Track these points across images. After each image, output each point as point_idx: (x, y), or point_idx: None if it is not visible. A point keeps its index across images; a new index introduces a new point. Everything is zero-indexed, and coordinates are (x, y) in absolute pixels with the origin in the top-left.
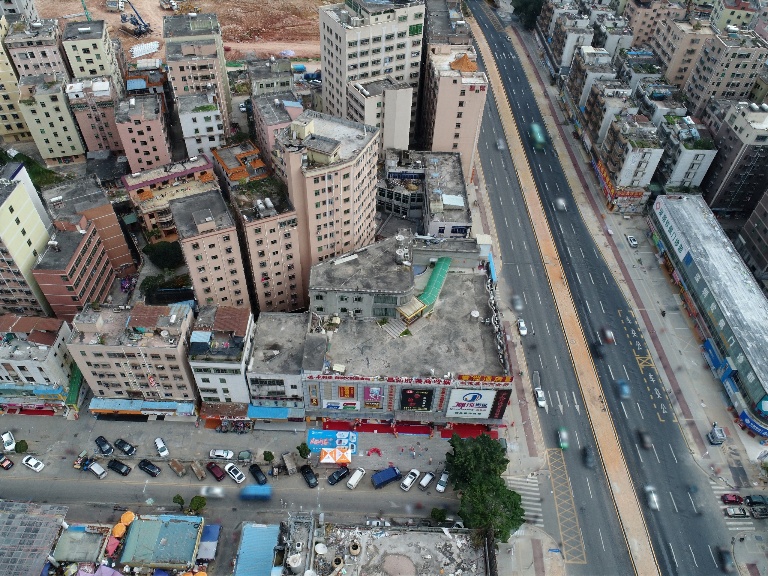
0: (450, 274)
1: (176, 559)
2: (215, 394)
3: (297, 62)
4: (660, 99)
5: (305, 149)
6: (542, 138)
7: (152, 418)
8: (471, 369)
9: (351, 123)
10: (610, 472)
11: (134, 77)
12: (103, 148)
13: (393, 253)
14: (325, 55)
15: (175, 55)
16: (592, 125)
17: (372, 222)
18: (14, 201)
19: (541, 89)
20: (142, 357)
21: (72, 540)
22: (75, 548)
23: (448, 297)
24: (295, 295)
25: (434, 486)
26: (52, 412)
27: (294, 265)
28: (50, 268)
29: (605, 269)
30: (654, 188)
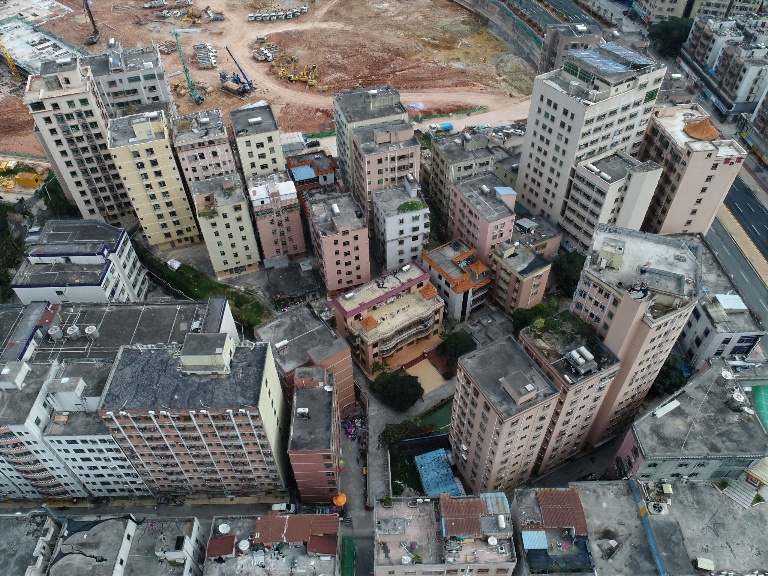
0: None
1: None
2: None
3: (437, 118)
4: None
5: (656, 295)
6: (740, 191)
7: None
8: None
9: (660, 239)
10: None
11: (299, 164)
12: (280, 253)
13: (720, 394)
14: (536, 130)
15: (367, 144)
16: None
17: None
18: (267, 371)
19: None
20: (465, 572)
21: None
22: None
23: None
24: (579, 442)
25: None
26: None
27: (592, 414)
28: (308, 445)
29: None
30: None
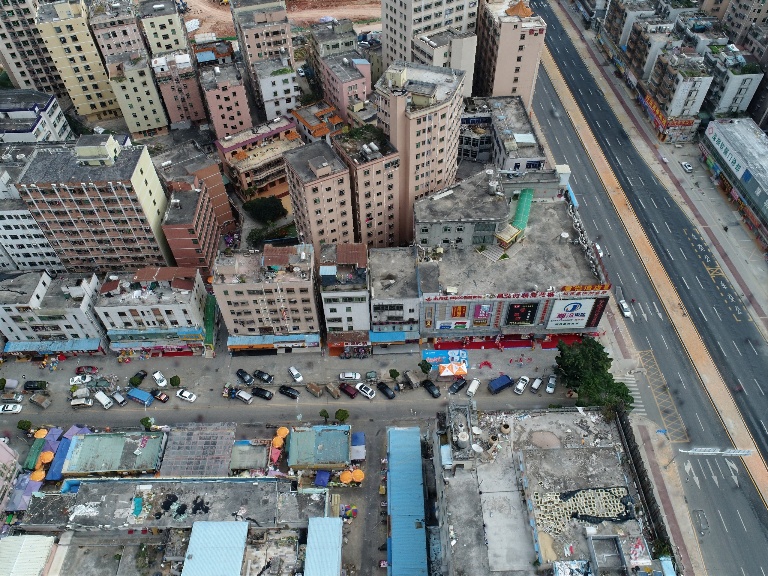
0: (533, 204)
1: (335, 460)
2: (340, 323)
3: None
4: (701, 31)
5: (410, 92)
6: (586, 80)
7: (281, 351)
8: (569, 283)
9: (438, 69)
10: (699, 366)
11: (202, 50)
12: (184, 119)
13: (484, 186)
14: (387, 12)
15: (248, 24)
16: (636, 62)
17: (455, 163)
18: (142, 164)
19: (577, 34)
20: (278, 292)
21: (241, 452)
22: (245, 458)
23: (535, 224)
24: (392, 234)
25: (544, 389)
26: (191, 353)
27: (393, 205)
28: (177, 223)
29: (665, 194)
30: (703, 116)
